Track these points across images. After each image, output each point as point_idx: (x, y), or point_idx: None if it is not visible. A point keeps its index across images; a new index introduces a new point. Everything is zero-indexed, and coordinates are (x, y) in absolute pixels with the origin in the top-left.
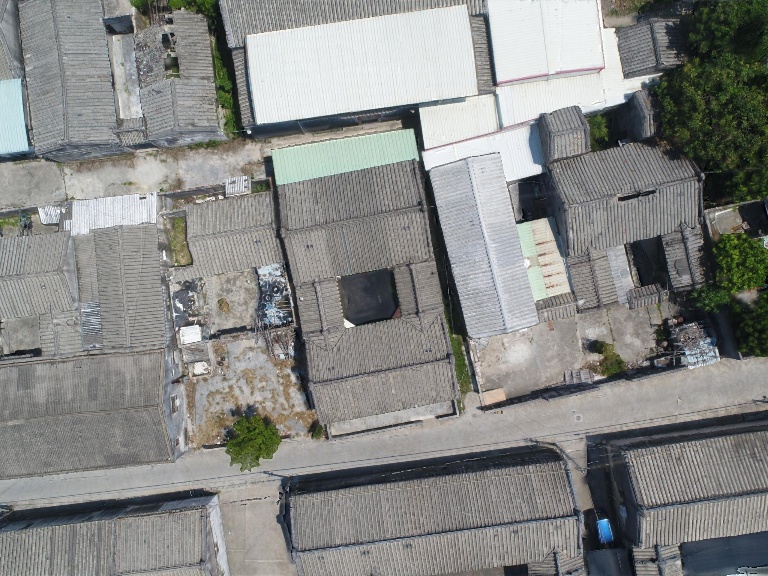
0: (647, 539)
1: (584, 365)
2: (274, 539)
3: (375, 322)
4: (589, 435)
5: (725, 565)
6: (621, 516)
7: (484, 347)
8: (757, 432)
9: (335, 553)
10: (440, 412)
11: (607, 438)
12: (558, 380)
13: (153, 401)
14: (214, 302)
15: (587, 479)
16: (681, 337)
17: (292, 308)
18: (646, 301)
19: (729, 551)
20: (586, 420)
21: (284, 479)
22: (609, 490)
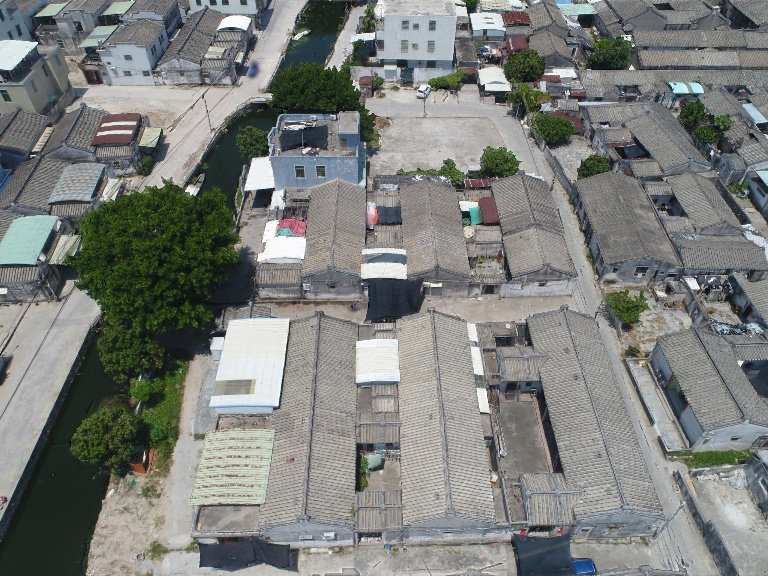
0: None
1: None
2: None
3: None
4: None
5: None
6: None
7: (733, 485)
8: None
9: (565, 332)
10: None
11: None
12: None
13: (651, 254)
14: None
15: (623, 567)
16: None
17: None
18: None
19: None
20: None
21: None
22: None
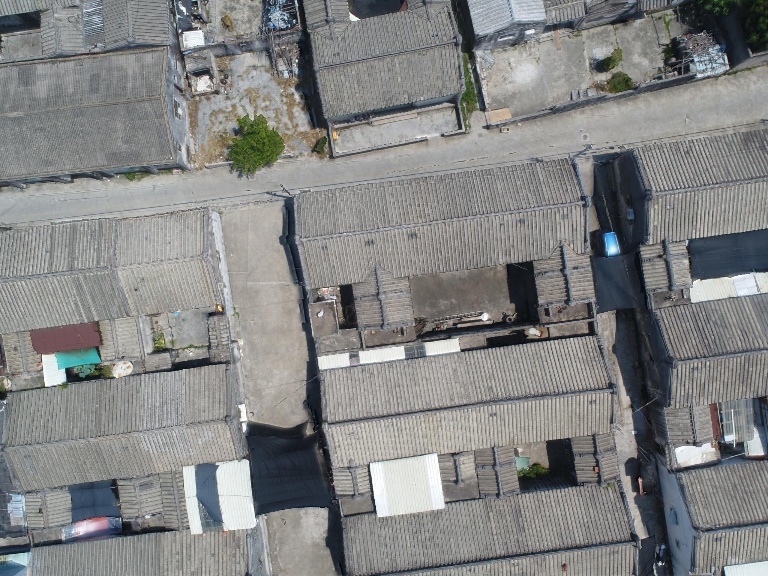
0: (655, 233)
1: (591, 85)
2: (277, 261)
3: (381, 15)
4: (596, 155)
5: (733, 266)
6: (628, 228)
7: (490, 66)
8: (766, 129)
9: (339, 242)
10: (445, 130)
11: (614, 158)
12: (565, 100)
13: (155, 92)
14: (217, 20)
15: (593, 200)
16: (690, 45)
17: (297, 8)
18: (655, 2)
19: (737, 252)
20: (593, 139)
21: (287, 200)
22: (616, 211)
